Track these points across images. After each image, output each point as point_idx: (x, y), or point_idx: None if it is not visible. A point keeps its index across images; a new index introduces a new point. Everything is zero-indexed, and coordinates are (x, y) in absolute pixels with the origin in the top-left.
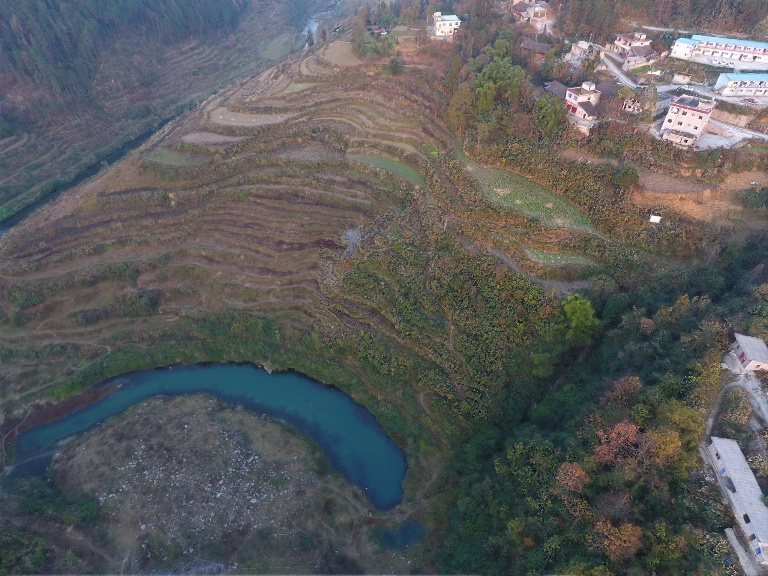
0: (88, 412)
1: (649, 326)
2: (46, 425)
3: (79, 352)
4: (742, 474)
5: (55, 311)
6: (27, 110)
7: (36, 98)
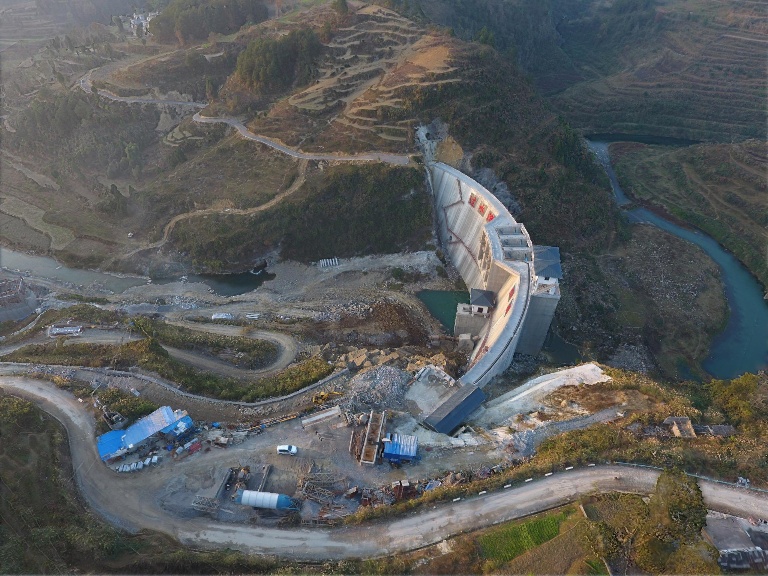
0: (671, 226)
1: None
2: (654, 214)
3: (705, 207)
4: None
5: (725, 185)
6: None
7: None
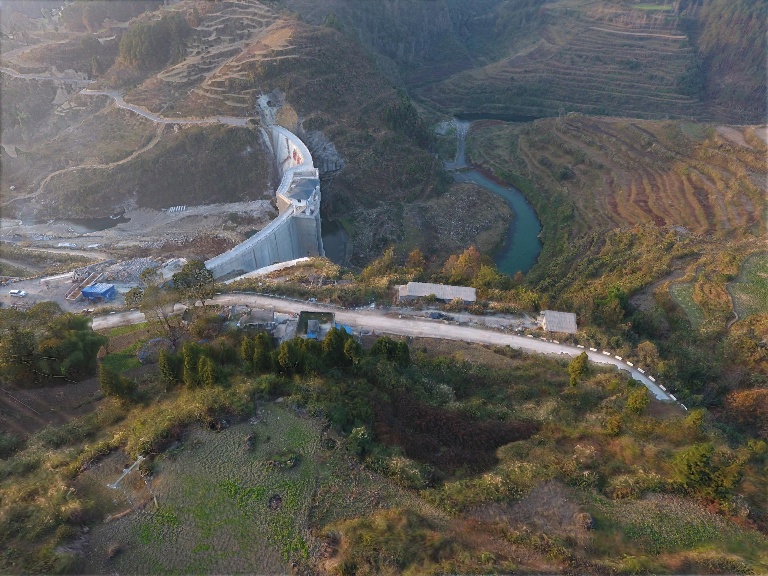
0: (492, 185)
1: (588, 305)
2: (481, 176)
3: (523, 169)
4: (450, 293)
5: (543, 151)
6: (723, 89)
7: (737, 85)
